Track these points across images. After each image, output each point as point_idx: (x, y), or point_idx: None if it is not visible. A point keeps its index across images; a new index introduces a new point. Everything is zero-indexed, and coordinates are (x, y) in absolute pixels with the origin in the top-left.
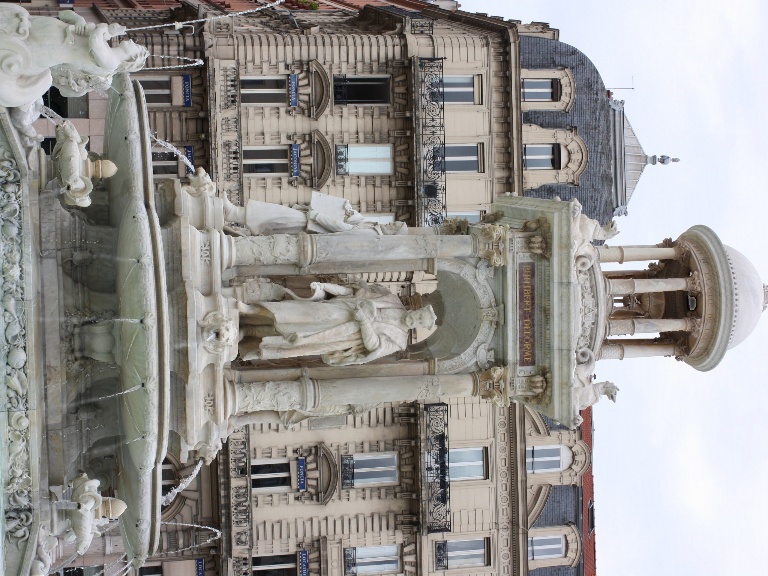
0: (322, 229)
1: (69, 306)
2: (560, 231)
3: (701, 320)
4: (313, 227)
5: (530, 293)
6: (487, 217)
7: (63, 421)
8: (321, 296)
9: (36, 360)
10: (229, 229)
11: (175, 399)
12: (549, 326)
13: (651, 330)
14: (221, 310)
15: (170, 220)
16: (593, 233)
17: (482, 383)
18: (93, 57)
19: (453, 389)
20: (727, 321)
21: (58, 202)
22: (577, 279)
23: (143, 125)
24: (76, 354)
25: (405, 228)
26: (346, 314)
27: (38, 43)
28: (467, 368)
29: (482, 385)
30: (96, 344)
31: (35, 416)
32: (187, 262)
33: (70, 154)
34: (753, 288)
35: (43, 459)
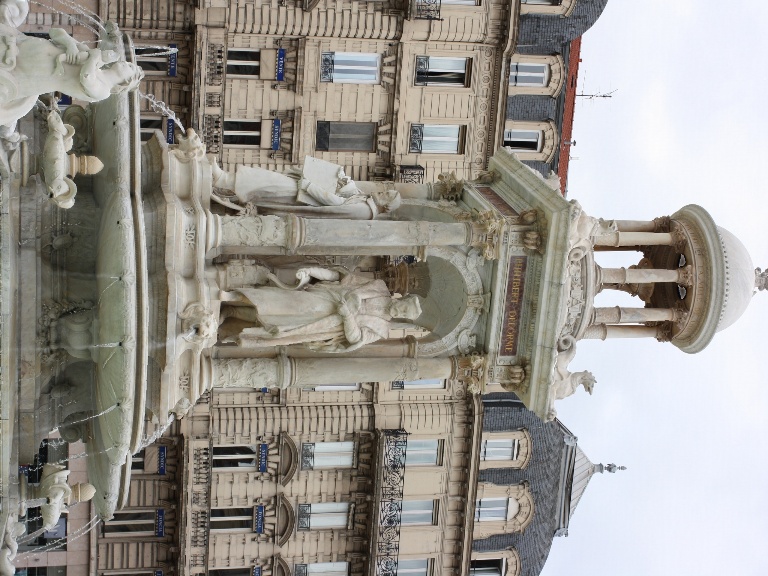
0: (313, 200)
1: (47, 299)
2: (557, 232)
3: (688, 314)
4: (303, 198)
5: (519, 286)
6: (484, 178)
7: (36, 403)
8: (306, 281)
9: (11, 367)
10: (216, 200)
11: (150, 378)
12: (534, 320)
13: (636, 320)
14: (203, 302)
15: (156, 192)
16: (590, 232)
17: (461, 370)
18: (84, 89)
19: (431, 374)
20: (714, 318)
21: (40, 189)
22: (568, 271)
23: (133, 105)
24: (52, 347)
25: (398, 199)
26: (330, 306)
27: (25, 74)
28: (447, 352)
29: (460, 372)
30: (73, 341)
31: (7, 425)
32: (171, 249)
33: (55, 156)
34: (745, 282)
35: (14, 443)
